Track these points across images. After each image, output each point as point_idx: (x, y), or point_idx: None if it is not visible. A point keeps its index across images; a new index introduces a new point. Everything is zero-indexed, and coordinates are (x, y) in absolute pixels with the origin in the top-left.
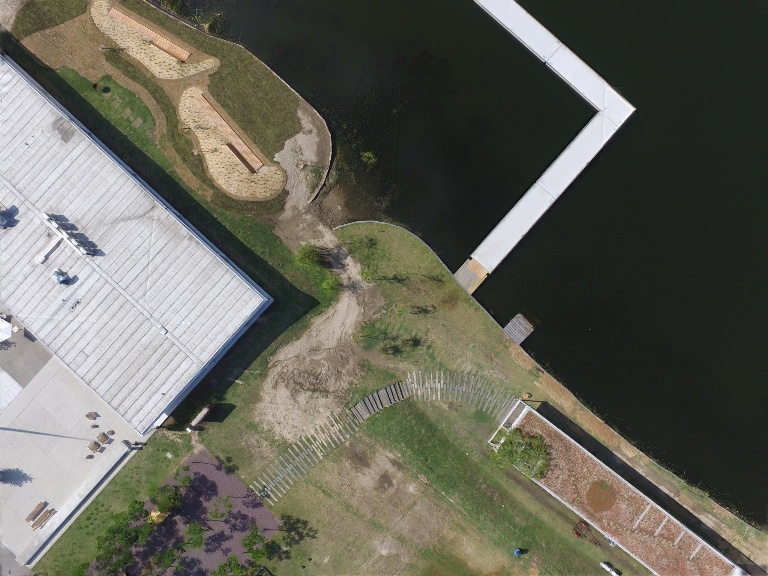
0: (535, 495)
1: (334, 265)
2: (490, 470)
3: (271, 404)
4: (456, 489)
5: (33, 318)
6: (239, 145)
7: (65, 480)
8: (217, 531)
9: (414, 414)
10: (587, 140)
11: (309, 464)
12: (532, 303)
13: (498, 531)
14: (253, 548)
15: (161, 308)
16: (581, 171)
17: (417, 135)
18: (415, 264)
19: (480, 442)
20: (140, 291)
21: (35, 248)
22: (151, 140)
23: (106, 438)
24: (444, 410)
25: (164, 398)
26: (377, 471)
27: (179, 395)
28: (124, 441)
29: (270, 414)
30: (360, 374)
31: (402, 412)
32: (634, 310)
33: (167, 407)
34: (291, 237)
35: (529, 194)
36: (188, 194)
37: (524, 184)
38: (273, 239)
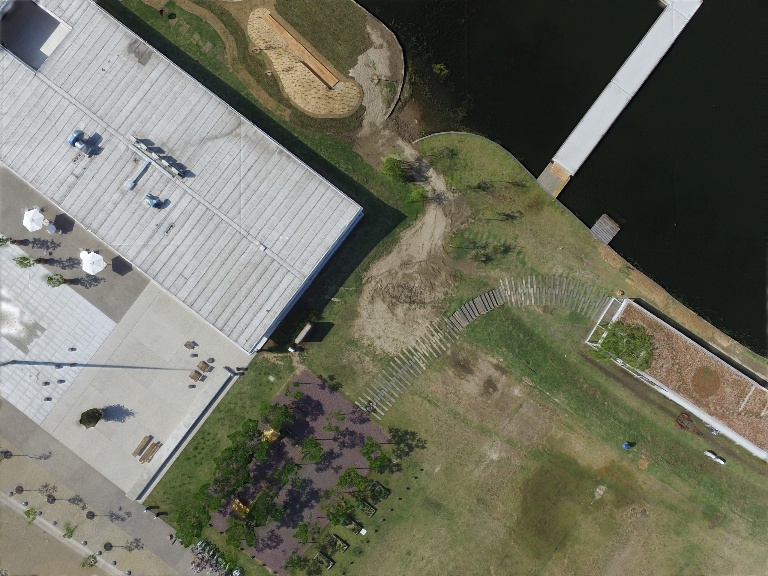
0: (635, 391)
1: (417, 178)
2: (589, 370)
3: (369, 319)
4: (560, 389)
5: (128, 245)
6: (312, 63)
7: (168, 412)
8: (326, 450)
9: (510, 320)
10: (658, 35)
11: (412, 376)
12: (616, 203)
13: (605, 427)
14: (371, 456)
15: (257, 225)
16: (655, 67)
17: (487, 43)
18: (498, 171)
19: (577, 343)
20: (234, 209)
21: (122, 175)
22: (223, 64)
23: (207, 366)
24: (539, 314)
25: (269, 315)
26: (481, 377)
27: (283, 311)
28: (225, 367)
29: (369, 329)
30: (453, 284)
31: (499, 318)
32: (717, 202)
33: (272, 324)
34: (371, 154)
35: (605, 93)
36: (266, 115)
37: (598, 85)
38: (354, 156)
